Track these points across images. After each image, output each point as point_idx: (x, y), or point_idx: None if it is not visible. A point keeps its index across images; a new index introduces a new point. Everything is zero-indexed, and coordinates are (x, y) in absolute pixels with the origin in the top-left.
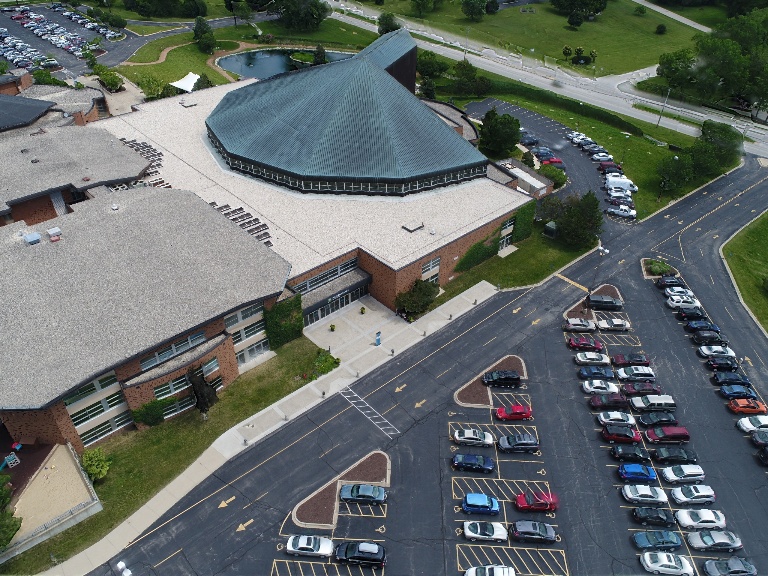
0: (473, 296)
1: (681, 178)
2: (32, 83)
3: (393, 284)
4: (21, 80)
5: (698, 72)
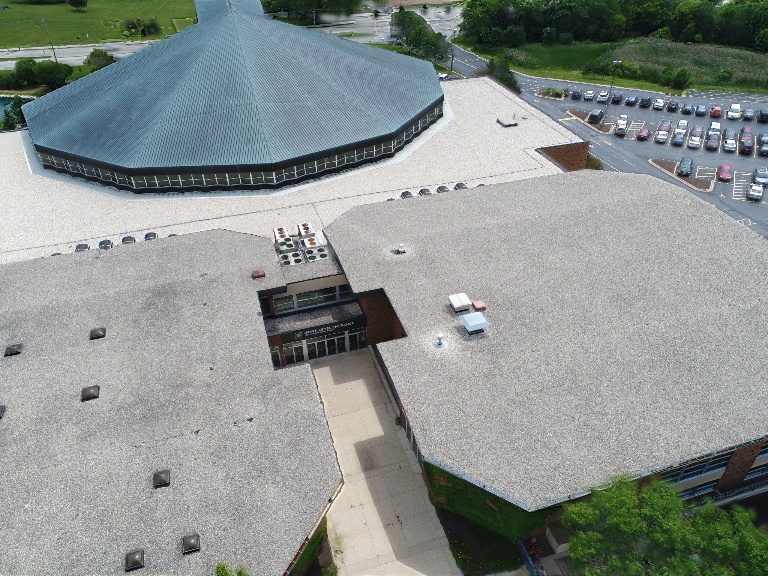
0: None
1: (445, 51)
2: None
3: (584, 158)
4: None
5: (284, 1)
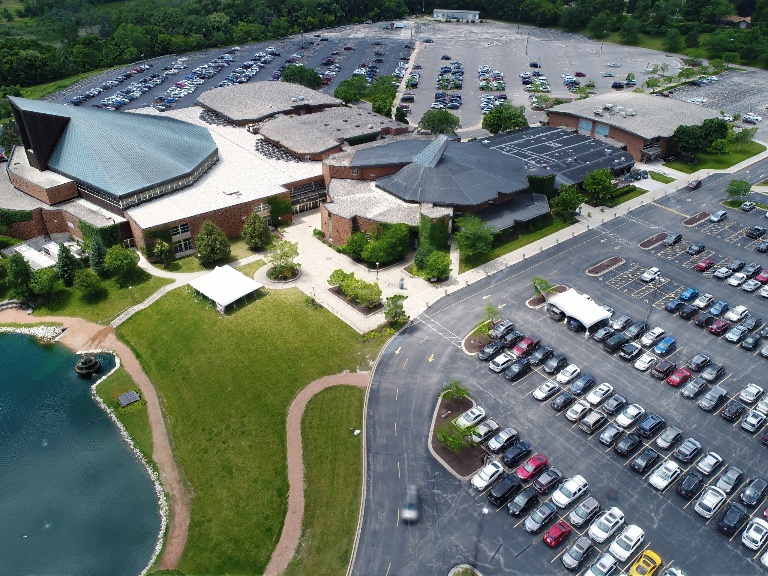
0: None
1: None
2: None
3: None
4: None
5: None
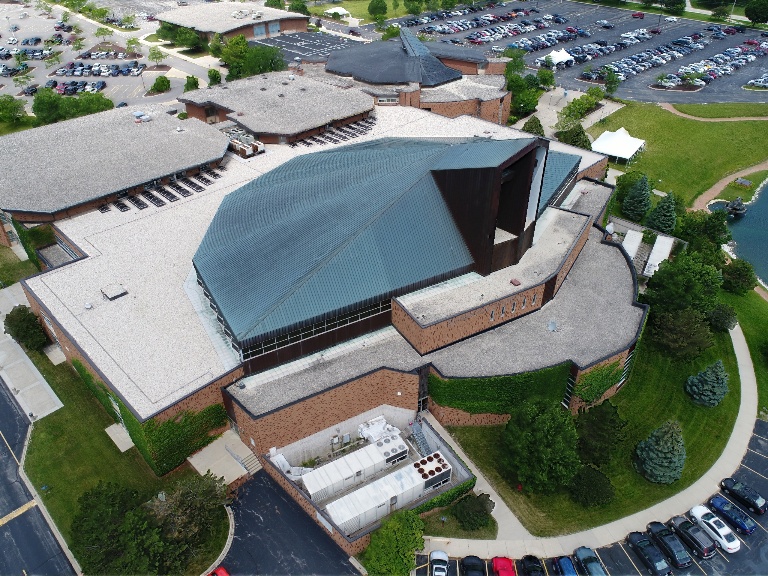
0: (34, 392)
1: None
2: (502, 73)
3: None
4: (489, 65)
5: None
